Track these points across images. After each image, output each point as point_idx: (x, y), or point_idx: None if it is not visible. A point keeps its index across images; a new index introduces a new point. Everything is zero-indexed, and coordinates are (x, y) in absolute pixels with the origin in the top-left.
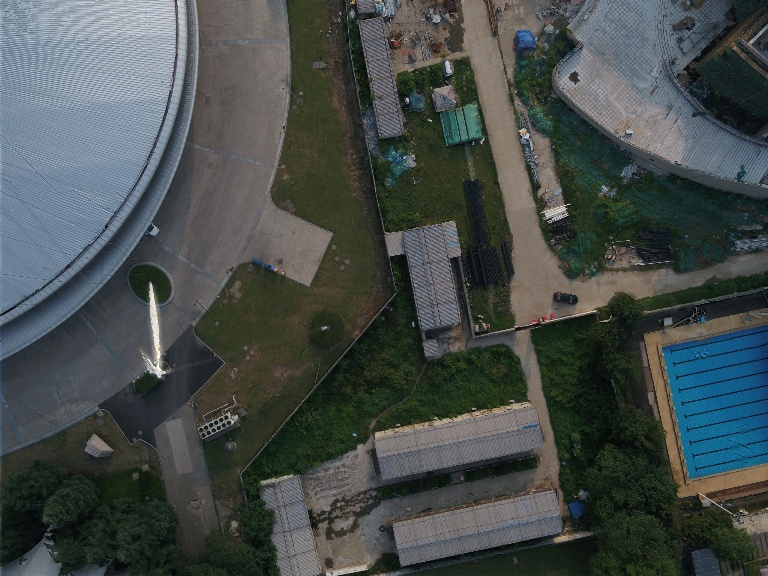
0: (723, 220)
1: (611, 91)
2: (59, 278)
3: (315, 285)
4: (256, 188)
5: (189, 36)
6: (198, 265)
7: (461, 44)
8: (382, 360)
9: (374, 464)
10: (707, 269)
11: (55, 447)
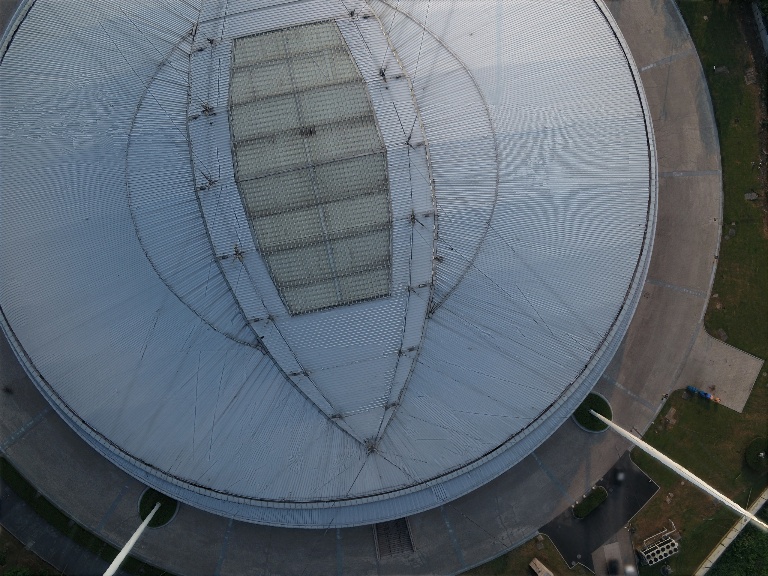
0: None
1: None
2: (542, 417)
3: (747, 411)
4: (690, 317)
5: None
6: (634, 392)
7: None
8: None
9: None
10: None
11: (496, 571)
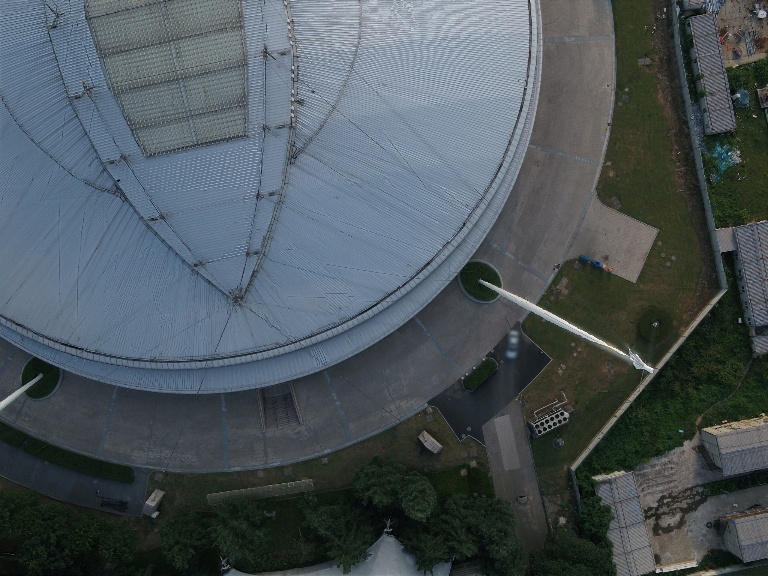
0: None
1: None
2: (419, 275)
3: (641, 282)
4: (582, 185)
5: None
6: (525, 262)
7: None
8: (709, 356)
9: (706, 460)
10: None
11: (385, 443)
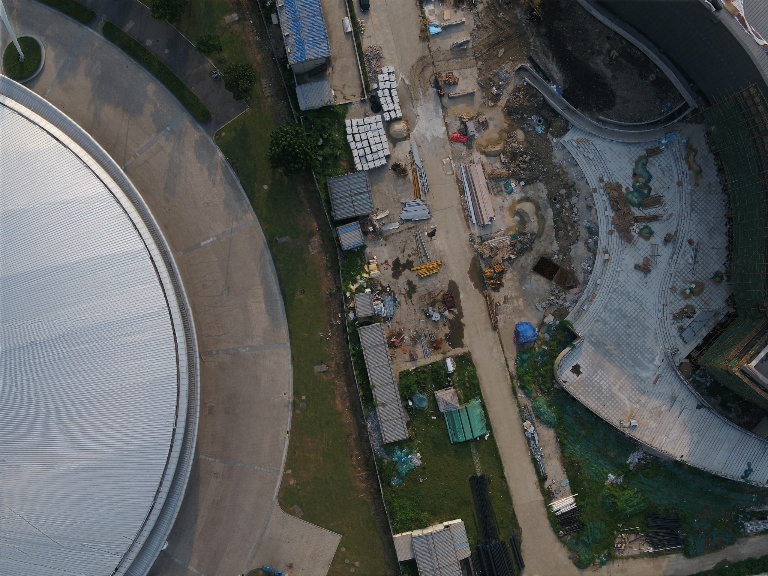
0: (731, 502)
1: (614, 382)
2: None
3: None
4: (263, 494)
5: (190, 366)
6: (208, 575)
7: (461, 339)
8: None
9: None
10: (717, 552)
11: None
